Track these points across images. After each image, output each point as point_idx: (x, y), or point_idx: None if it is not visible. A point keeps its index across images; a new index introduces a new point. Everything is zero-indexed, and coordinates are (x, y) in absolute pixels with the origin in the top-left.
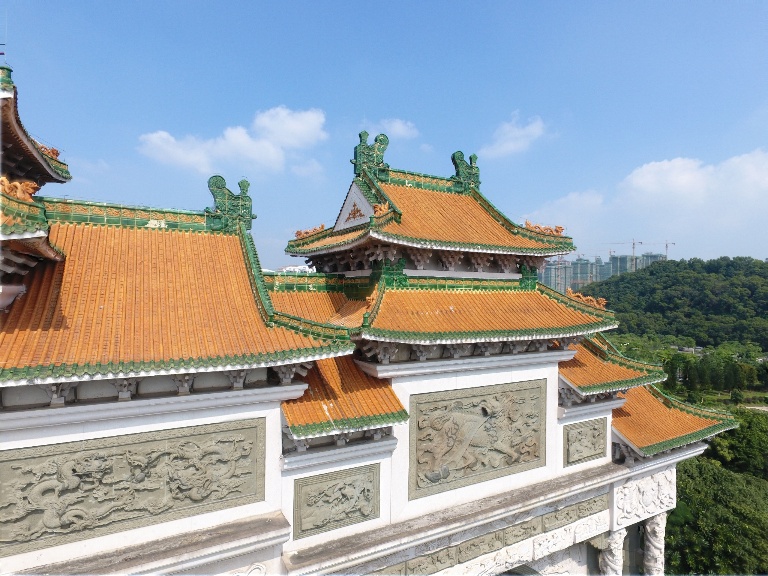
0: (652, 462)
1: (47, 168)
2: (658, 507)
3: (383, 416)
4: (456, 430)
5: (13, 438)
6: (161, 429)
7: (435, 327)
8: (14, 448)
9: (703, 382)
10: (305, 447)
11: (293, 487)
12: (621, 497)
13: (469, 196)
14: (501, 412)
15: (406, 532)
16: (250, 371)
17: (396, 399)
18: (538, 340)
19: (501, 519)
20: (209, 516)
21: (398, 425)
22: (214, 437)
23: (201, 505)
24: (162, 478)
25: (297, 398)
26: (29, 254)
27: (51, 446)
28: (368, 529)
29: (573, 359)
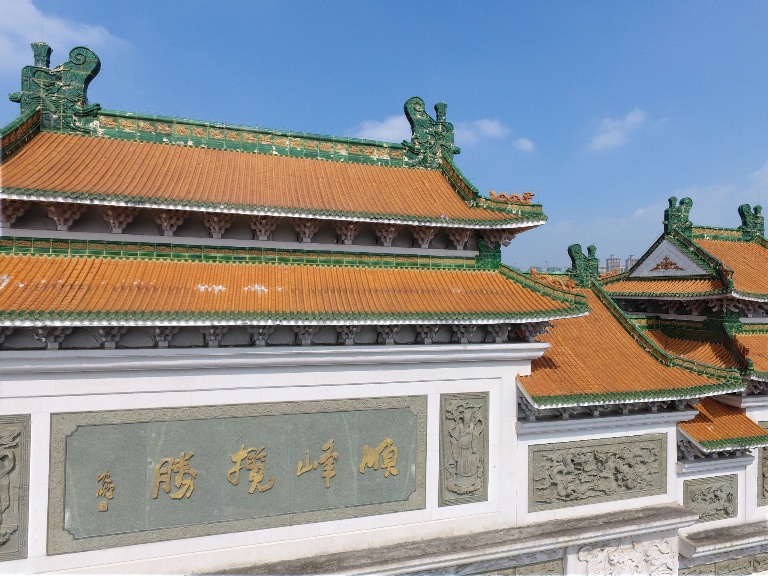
0: None
1: None
2: None
3: None
4: None
5: (543, 437)
6: (611, 437)
7: None
8: (544, 443)
9: None
10: (693, 457)
11: (683, 486)
12: None
13: (755, 243)
14: None
15: (765, 531)
16: None
17: (757, 425)
18: None
19: None
20: (636, 500)
21: None
22: (638, 445)
23: (631, 492)
24: (611, 470)
25: None
26: None
27: (559, 444)
28: (730, 525)
29: None
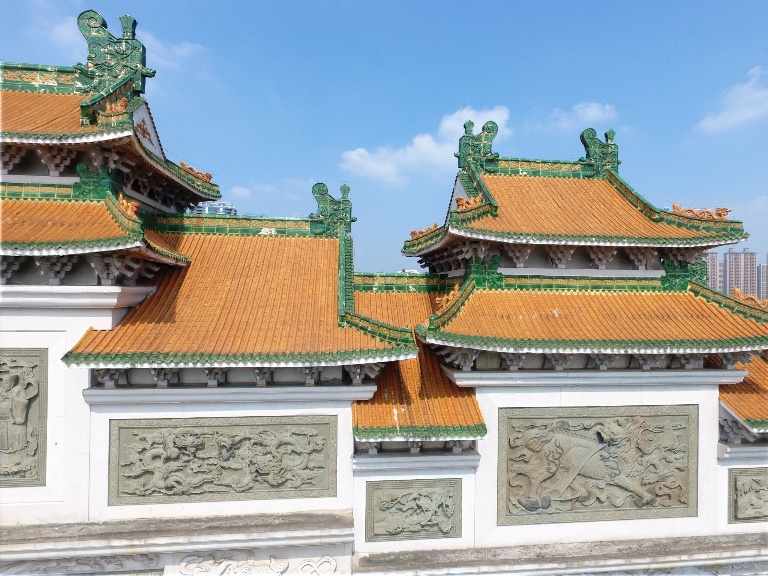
0: None
1: (193, 190)
2: None
3: (455, 428)
4: (559, 454)
5: (133, 410)
6: (243, 416)
7: (525, 333)
8: (134, 418)
9: None
10: (376, 450)
11: (365, 488)
12: None
13: (603, 180)
14: (624, 440)
15: (488, 560)
16: (322, 369)
17: (477, 411)
18: (683, 354)
19: (626, 571)
20: (284, 502)
21: (484, 440)
22: (289, 429)
23: (278, 491)
24: (244, 460)
25: (369, 399)
26: (154, 261)
27: (159, 420)
28: (448, 547)
29: (749, 382)
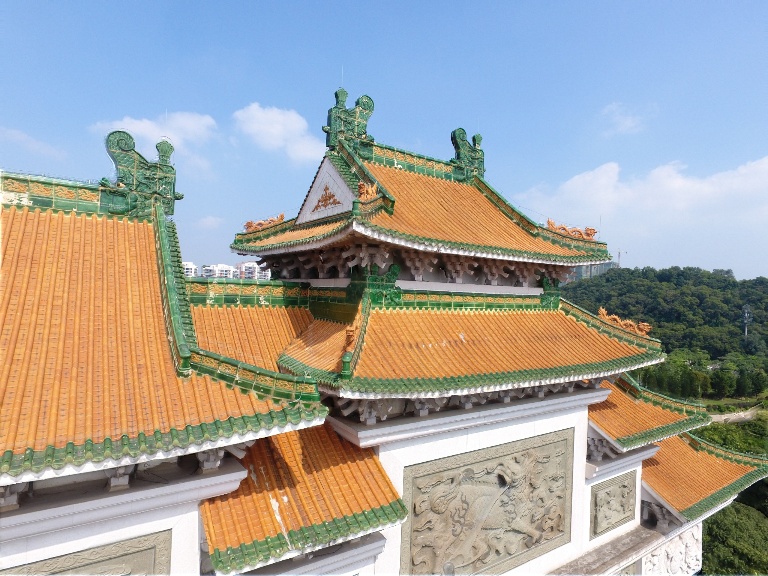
0: (687, 523)
1: None
2: (685, 572)
3: (368, 516)
4: (465, 511)
5: None
6: None
7: (445, 368)
8: None
9: (661, 390)
10: None
11: None
12: (649, 568)
13: (471, 186)
14: (522, 479)
15: None
16: None
17: (386, 480)
18: None
19: None
20: None
21: None
22: None
23: None
24: None
25: None
26: None
27: None
28: None
29: None
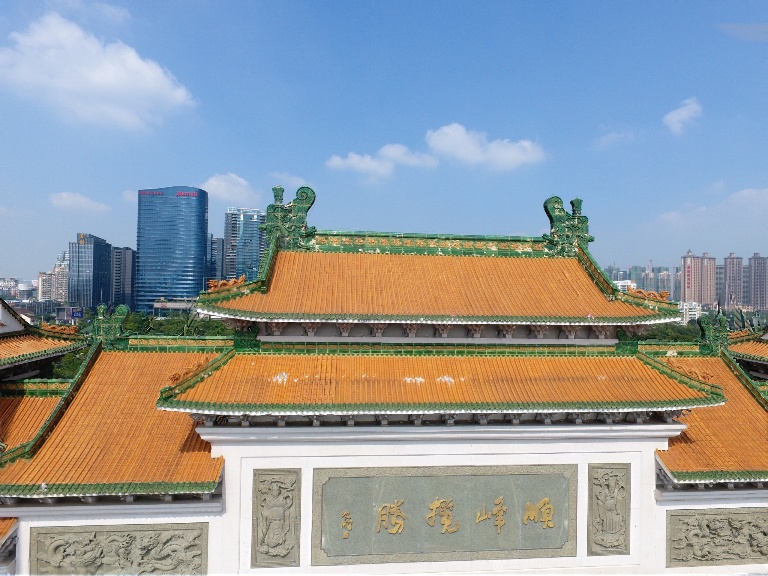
0: None
1: None
2: None
3: None
4: None
5: (680, 504)
6: (746, 507)
7: None
8: (680, 509)
9: None
10: None
11: None
12: None
13: None
14: None
15: None
16: None
17: None
18: None
19: None
20: None
21: None
22: None
23: (766, 558)
24: (745, 537)
25: None
26: None
27: (695, 510)
28: None
29: None
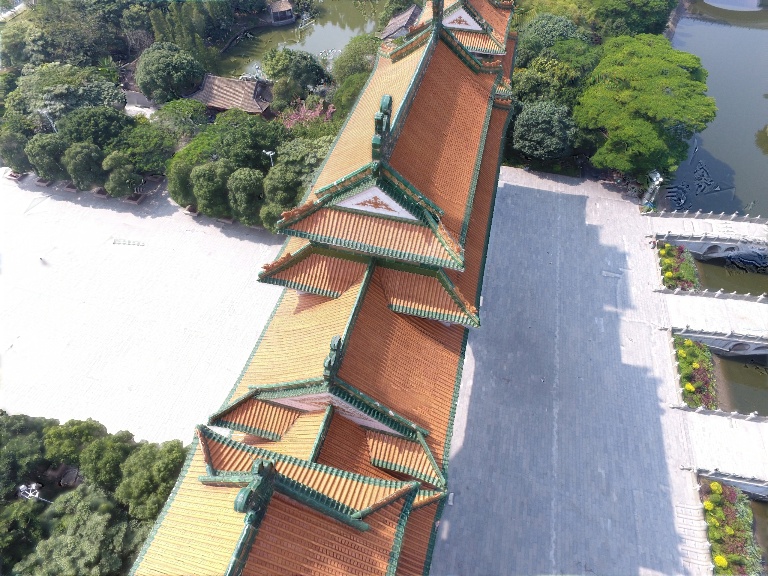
0: None
1: (396, 257)
2: None
3: None
4: None
5: None
6: None
7: None
8: None
9: None
10: None
11: None
12: None
13: None
14: None
15: None
16: None
17: None
18: None
19: None
20: None
21: None
22: None
23: None
24: None
25: None
26: None
27: None
28: None
29: None
